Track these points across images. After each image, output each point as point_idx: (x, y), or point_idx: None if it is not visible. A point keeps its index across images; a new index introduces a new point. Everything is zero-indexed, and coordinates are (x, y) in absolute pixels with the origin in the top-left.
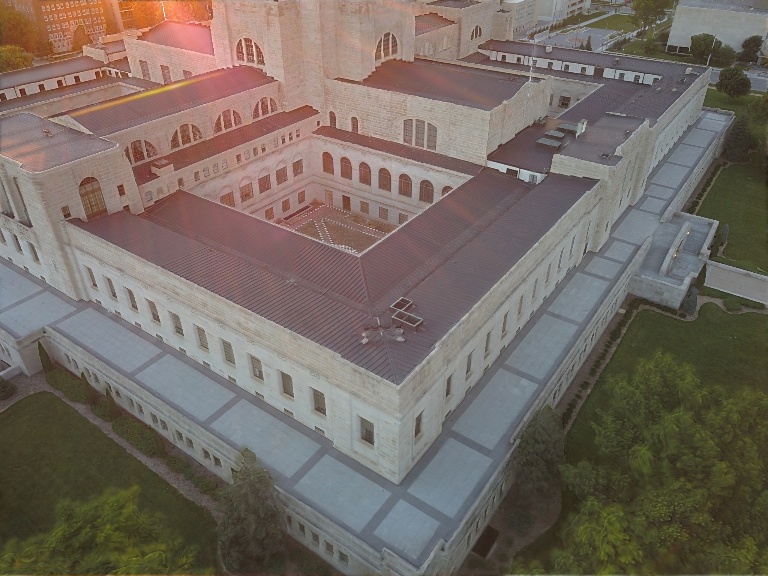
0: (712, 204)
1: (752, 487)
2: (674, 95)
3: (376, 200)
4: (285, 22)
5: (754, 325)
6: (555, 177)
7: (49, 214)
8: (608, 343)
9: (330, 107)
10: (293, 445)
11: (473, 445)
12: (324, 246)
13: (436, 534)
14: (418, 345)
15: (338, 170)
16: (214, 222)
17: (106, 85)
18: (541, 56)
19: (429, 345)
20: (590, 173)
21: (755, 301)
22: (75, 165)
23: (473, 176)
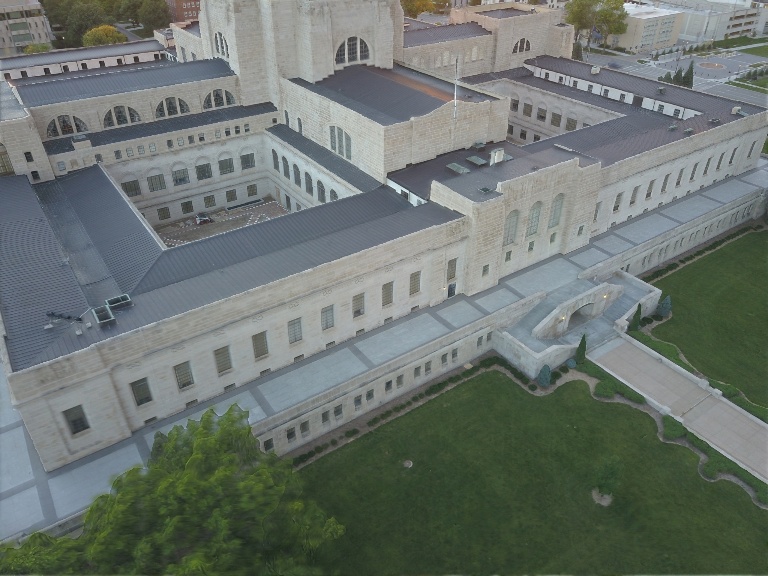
0: (694, 271)
1: (126, 568)
2: (684, 136)
3: (304, 203)
4: (242, 19)
5: (612, 419)
6: (430, 206)
7: None
8: (418, 396)
9: (284, 106)
10: (6, 410)
11: (147, 456)
12: (147, 235)
13: (30, 527)
14: (84, 341)
15: (281, 169)
16: (93, 197)
17: None
18: (583, 77)
19: (92, 343)
20: (458, 207)
21: (636, 392)
22: None
23: (362, 192)
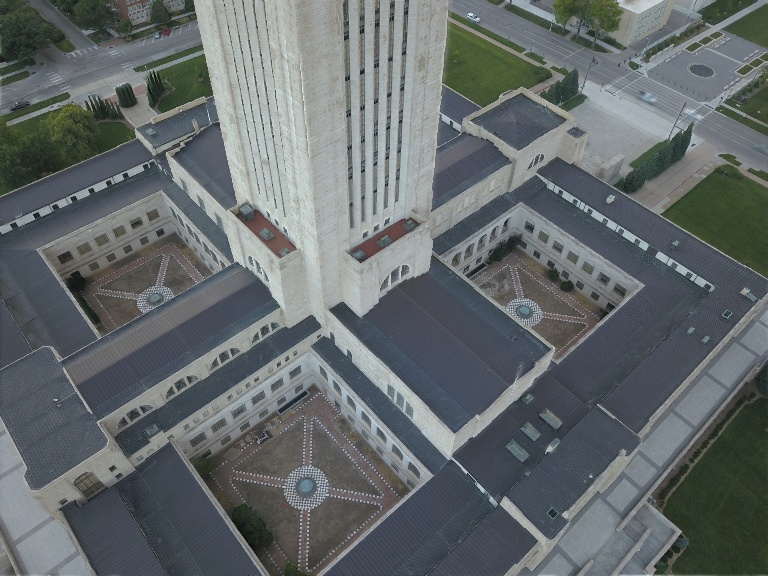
0: (702, 473)
1: None
2: (702, 348)
3: (359, 425)
4: (287, 270)
5: None
6: (502, 514)
7: (48, 510)
8: None
9: (330, 329)
10: None
11: None
12: None
13: None
14: None
15: (331, 384)
16: (186, 507)
17: (148, 196)
18: (598, 208)
19: None
20: (531, 531)
21: None
22: (68, 475)
23: (432, 476)
